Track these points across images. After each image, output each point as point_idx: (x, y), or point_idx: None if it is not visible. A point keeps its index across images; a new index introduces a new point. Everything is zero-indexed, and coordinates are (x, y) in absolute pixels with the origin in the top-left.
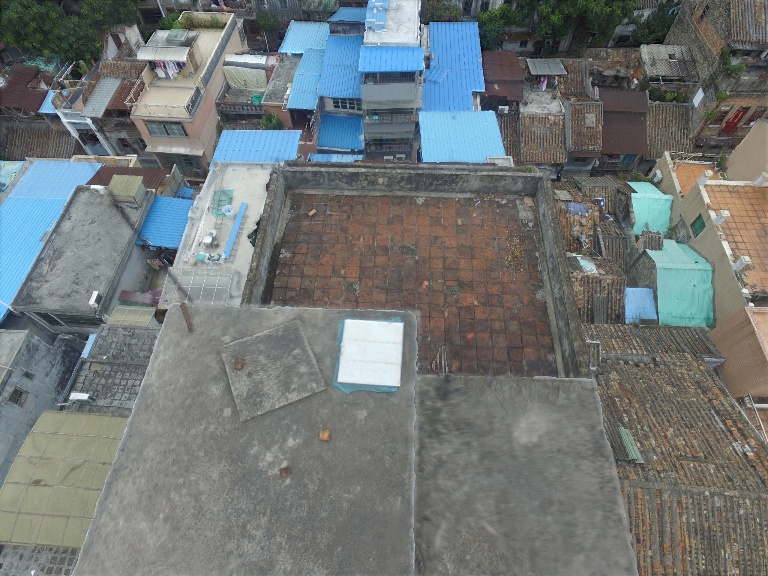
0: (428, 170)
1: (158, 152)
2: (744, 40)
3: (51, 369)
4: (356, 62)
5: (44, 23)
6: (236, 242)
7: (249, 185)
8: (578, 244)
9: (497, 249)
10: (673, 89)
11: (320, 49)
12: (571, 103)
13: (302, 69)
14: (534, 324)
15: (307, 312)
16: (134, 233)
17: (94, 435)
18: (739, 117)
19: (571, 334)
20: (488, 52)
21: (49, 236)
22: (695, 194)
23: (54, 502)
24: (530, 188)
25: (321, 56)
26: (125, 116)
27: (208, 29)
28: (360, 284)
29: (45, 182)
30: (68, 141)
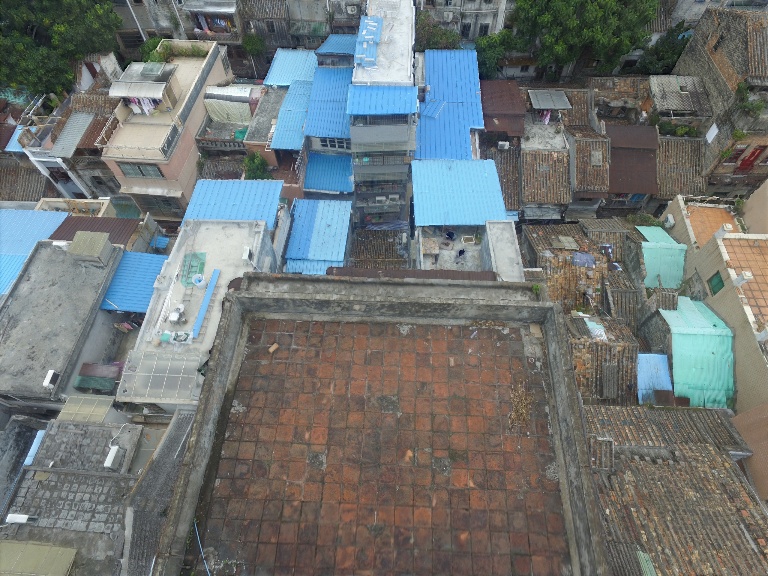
0: (414, 297)
1: (133, 193)
2: (763, 76)
3: (2, 456)
4: (345, 97)
5: (10, 55)
6: (206, 317)
7: (223, 247)
8: (584, 299)
9: (498, 401)
10: (684, 122)
11: (308, 81)
12: (576, 140)
13: (288, 104)
14: (544, 517)
15: None
16: (98, 298)
17: (29, 573)
18: (756, 155)
19: (593, 552)
20: (487, 82)
21: (4, 302)
22: (712, 248)
23: None
24: (537, 316)
25: (309, 89)
26: (98, 154)
27: (189, 58)
28: (328, 455)
29: (5, 234)
30: (38, 179)
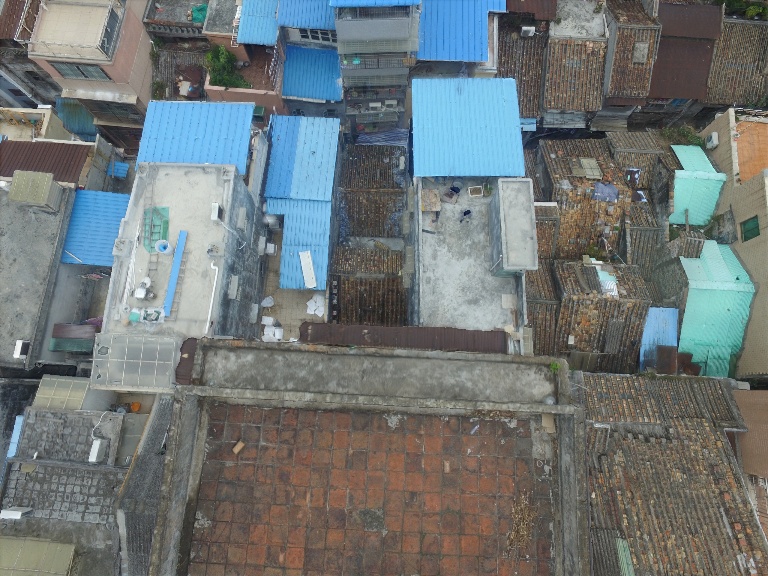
0: (404, 399)
1: (79, 98)
2: None
3: None
4: None
5: None
6: (177, 291)
7: (188, 200)
8: (600, 238)
9: (496, 516)
10: None
11: None
12: (619, 27)
13: None
14: None
15: None
16: (55, 252)
17: (33, 569)
18: None
19: None
20: None
21: None
22: (756, 187)
23: None
24: None
25: None
26: (25, 44)
27: None
28: None
29: None
30: None
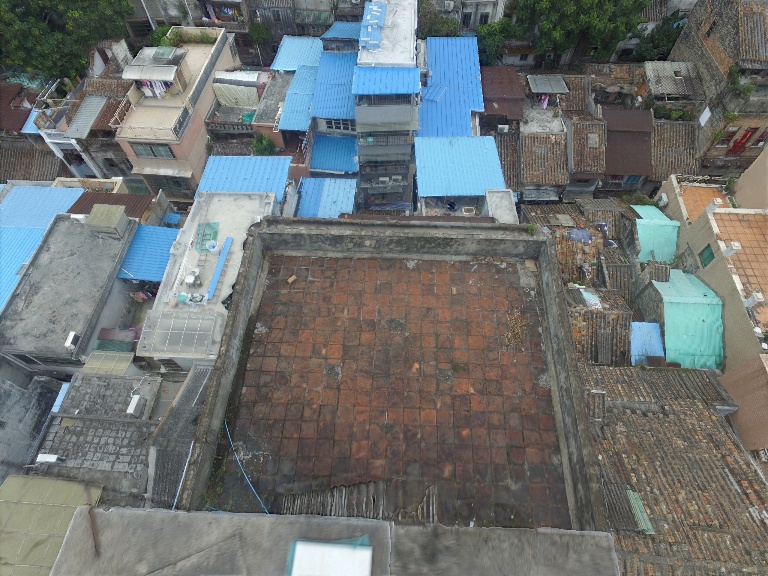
0: (420, 233)
1: (145, 174)
2: (753, 59)
3: (25, 414)
4: (350, 81)
5: (26, 40)
6: (220, 281)
7: (235, 217)
8: (581, 273)
9: (496, 323)
10: (678, 107)
11: (313, 66)
12: (573, 122)
13: (294, 88)
14: (537, 417)
15: (250, 521)
16: (115, 266)
17: (61, 504)
18: (747, 137)
19: (579, 438)
20: (487, 68)
21: (26, 270)
22: (703, 222)
23: None
24: (532, 251)
25: (314, 73)
26: (111, 136)
27: (198, 44)
28: (343, 367)
29: (24, 209)
30: (52, 161)
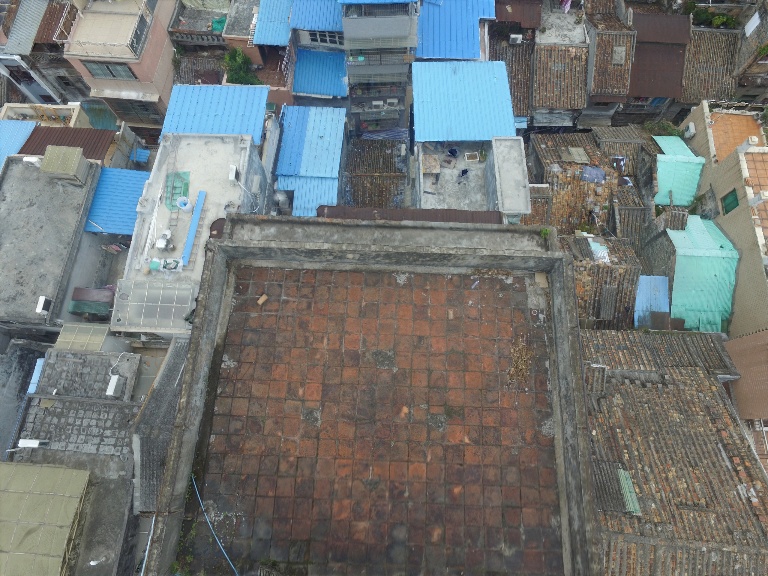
0: (412, 247)
1: (105, 97)
2: None
3: (8, 378)
4: None
5: None
6: (195, 244)
7: (208, 166)
8: (590, 217)
9: (497, 356)
10: (723, 11)
11: None
12: (598, 32)
13: None
14: (537, 472)
15: None
16: (80, 220)
17: (48, 493)
18: None
19: (583, 510)
20: None
21: None
22: (732, 163)
23: (12, 569)
24: (544, 265)
25: None
26: (60, 50)
27: None
28: (322, 411)
29: None
30: None
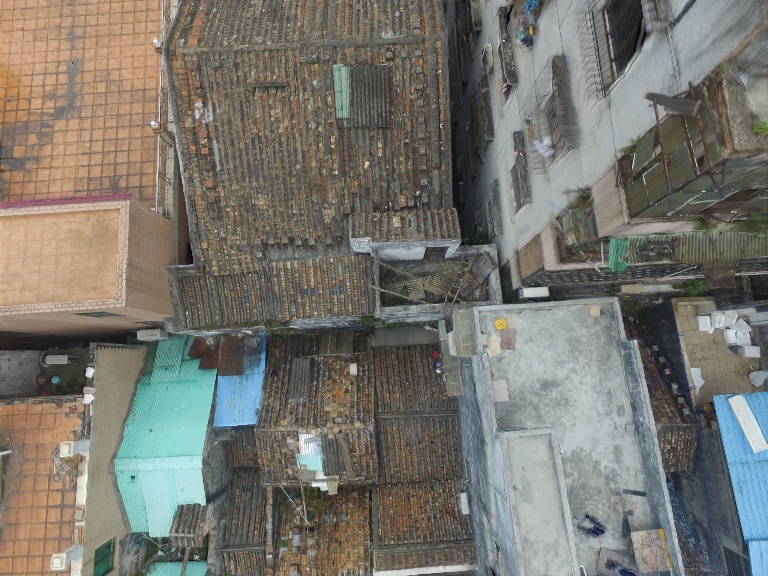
0: None
1: None
2: None
3: None
4: None
5: None
6: None
7: None
8: None
9: None
10: None
11: None
12: None
13: None
14: None
15: None
16: None
17: None
18: None
19: None
20: None
21: None
22: None
23: None
24: None
25: None
26: None
27: None
28: None
29: None
30: None
